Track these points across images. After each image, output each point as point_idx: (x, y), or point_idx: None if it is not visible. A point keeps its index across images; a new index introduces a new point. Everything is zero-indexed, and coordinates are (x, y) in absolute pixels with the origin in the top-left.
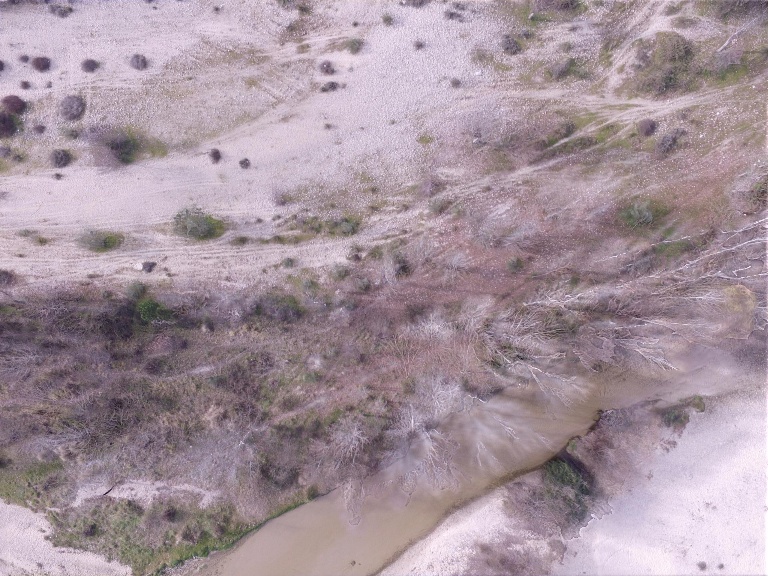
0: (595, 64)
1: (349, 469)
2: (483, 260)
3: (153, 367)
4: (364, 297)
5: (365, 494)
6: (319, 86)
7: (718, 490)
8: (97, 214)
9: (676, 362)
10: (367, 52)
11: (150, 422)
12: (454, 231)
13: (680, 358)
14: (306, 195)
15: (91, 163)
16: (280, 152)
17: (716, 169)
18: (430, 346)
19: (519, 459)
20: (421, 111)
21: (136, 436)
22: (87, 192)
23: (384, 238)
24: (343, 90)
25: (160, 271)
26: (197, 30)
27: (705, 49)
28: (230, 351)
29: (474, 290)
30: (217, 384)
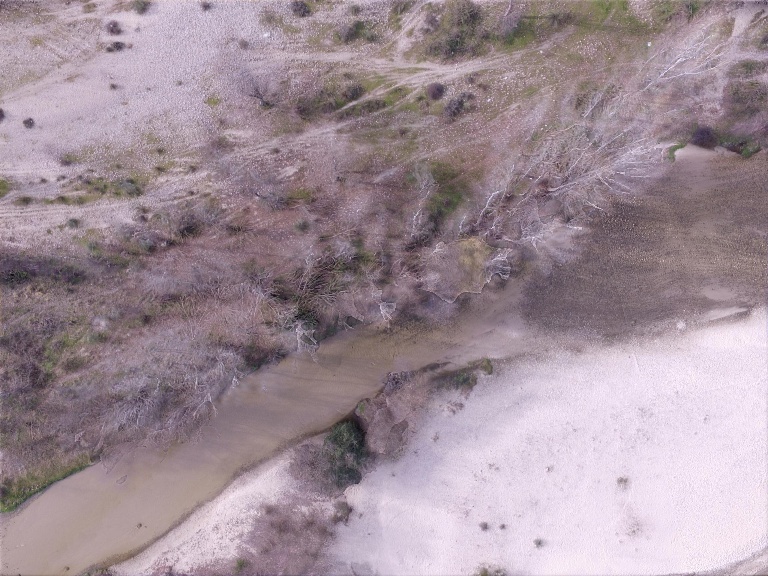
0: (384, 27)
1: (133, 431)
2: (271, 222)
3: None
4: (151, 259)
5: (117, 450)
6: (105, 46)
7: (501, 451)
8: None
9: (466, 325)
10: (154, 12)
11: None
12: (242, 193)
13: (470, 321)
14: (92, 156)
15: None
16: (65, 112)
17: (503, 133)
18: (217, 308)
19: (307, 421)
20: (209, 72)
21: None
22: None
23: (171, 199)
24: (129, 50)
25: None
26: None
27: (493, 14)
28: (14, 312)
29: (262, 252)
30: None
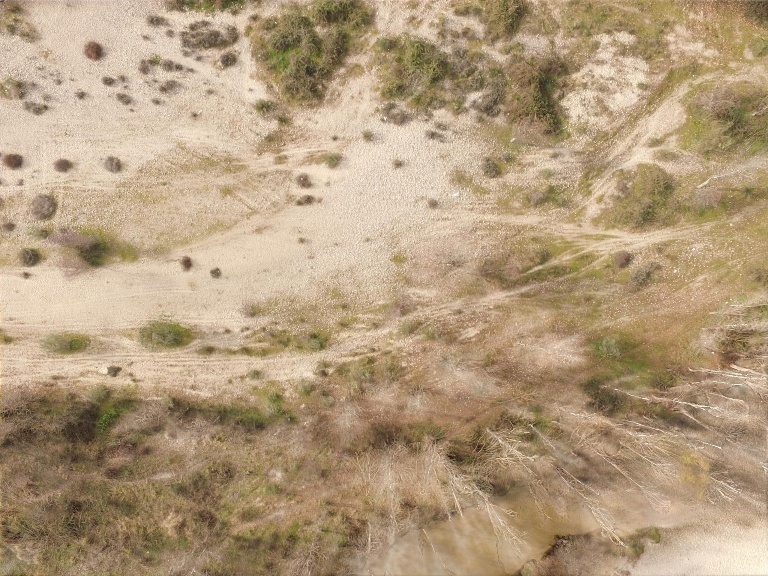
0: (574, 192)
1: None
2: (450, 382)
3: (113, 473)
4: (329, 413)
5: None
6: (295, 199)
7: None
8: (64, 315)
9: None
10: (345, 167)
11: (108, 526)
12: (422, 352)
13: None
14: (276, 308)
15: (60, 264)
16: (252, 263)
17: (688, 305)
18: (392, 465)
19: None
20: (396, 230)
21: (94, 539)
22: (55, 293)
23: (352, 355)
24: (319, 204)
25: (125, 376)
26: (174, 135)
27: (685, 184)
28: (192, 459)
29: (439, 412)
30: (177, 492)
